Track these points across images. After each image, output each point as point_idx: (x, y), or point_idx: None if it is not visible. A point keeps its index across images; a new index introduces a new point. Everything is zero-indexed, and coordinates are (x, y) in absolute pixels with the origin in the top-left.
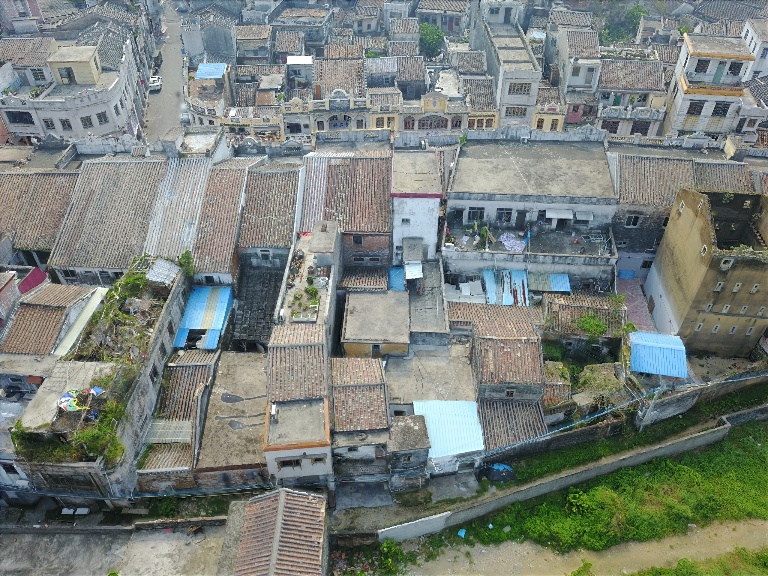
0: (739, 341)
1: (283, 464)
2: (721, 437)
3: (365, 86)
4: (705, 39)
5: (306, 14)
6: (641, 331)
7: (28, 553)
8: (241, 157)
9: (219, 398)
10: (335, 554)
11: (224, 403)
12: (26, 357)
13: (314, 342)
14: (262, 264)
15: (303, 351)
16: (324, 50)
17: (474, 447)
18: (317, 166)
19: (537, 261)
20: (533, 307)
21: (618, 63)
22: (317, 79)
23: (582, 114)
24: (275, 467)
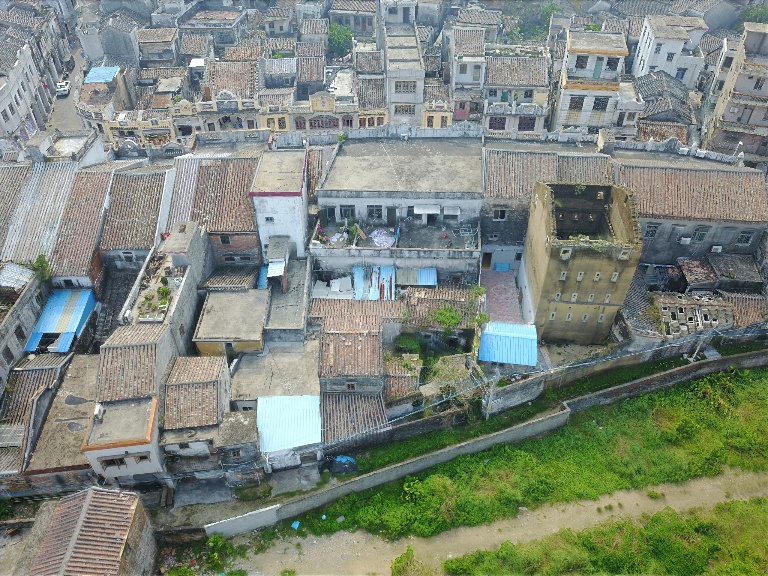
0: (593, 328)
1: (107, 463)
2: (563, 422)
3: (256, 87)
4: (586, 35)
5: (218, 16)
6: (500, 322)
7: None
8: (121, 160)
9: (63, 401)
10: (166, 551)
11: (67, 405)
12: None
13: (148, 342)
14: (127, 266)
15: (136, 351)
16: (226, 52)
17: (311, 440)
18: (188, 167)
19: (403, 256)
20: (398, 301)
21: (505, 60)
22: (209, 81)
23: (469, 111)
24: (100, 467)
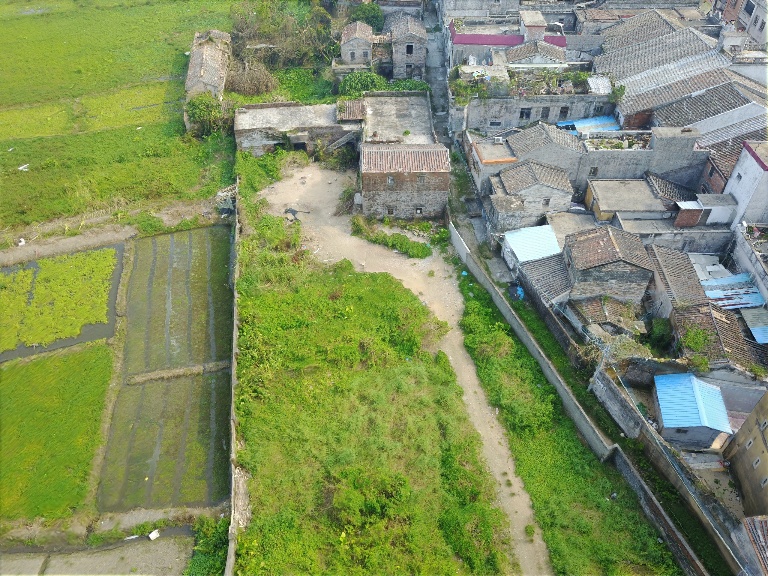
0: (762, 506)
1: None
2: (600, 454)
3: None
4: None
5: None
6: None
7: (420, 115)
8: None
9: None
10: (442, 221)
11: None
12: (505, 58)
13: None
14: None
15: None
16: None
17: (520, 256)
18: None
19: None
20: None
21: None
22: None
23: None
24: None
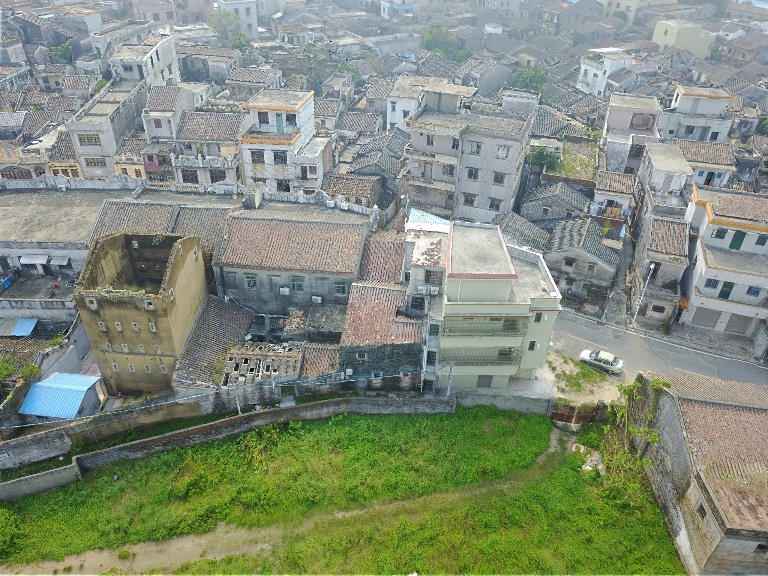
0: (162, 380)
1: None
2: (74, 478)
3: None
4: (276, 93)
5: None
6: None
7: None
8: None
9: None
10: None
11: None
12: None
13: None
14: None
15: None
16: None
17: None
18: None
19: None
20: None
21: (205, 115)
22: None
23: (158, 163)
24: None
